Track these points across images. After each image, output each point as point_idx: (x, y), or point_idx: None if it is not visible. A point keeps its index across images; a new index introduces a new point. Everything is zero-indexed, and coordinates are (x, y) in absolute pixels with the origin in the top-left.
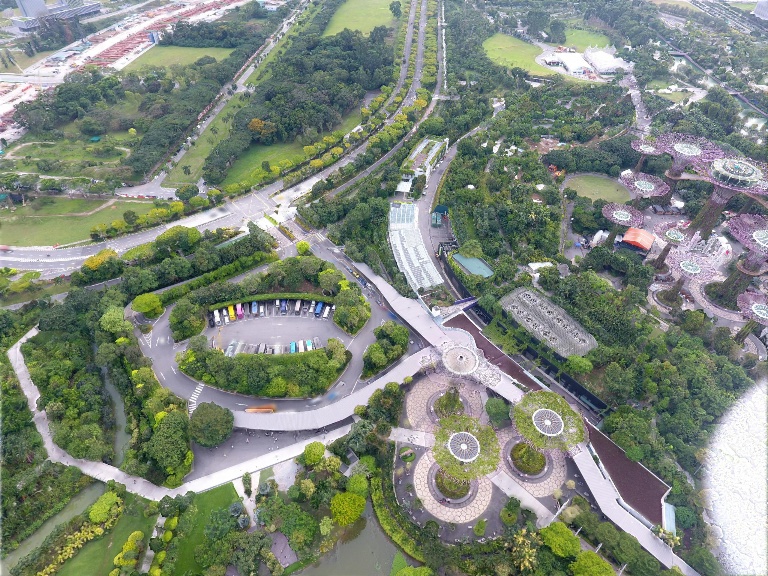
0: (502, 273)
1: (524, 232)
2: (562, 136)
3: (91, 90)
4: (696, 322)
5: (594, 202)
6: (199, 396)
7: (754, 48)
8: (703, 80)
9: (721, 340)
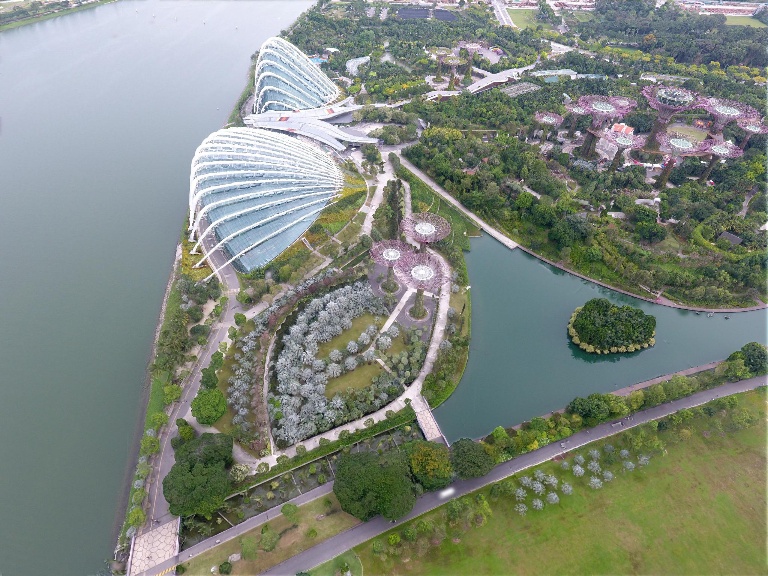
0: (550, 84)
1: (595, 94)
2: None
3: (643, 6)
4: None
5: None
6: (457, 50)
7: None
8: None
9: None
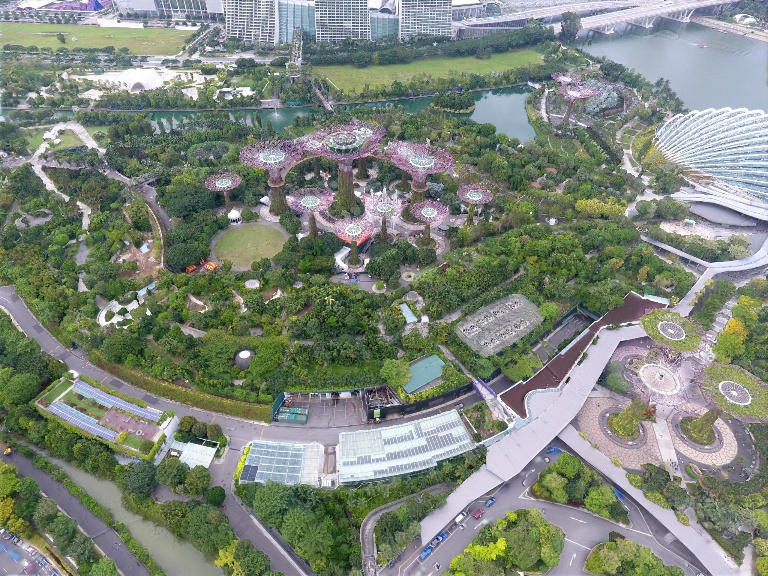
0: None
1: None
2: (134, 241)
3: None
4: (470, 234)
5: (285, 250)
6: None
7: (6, 68)
8: (54, 114)
9: (488, 228)
